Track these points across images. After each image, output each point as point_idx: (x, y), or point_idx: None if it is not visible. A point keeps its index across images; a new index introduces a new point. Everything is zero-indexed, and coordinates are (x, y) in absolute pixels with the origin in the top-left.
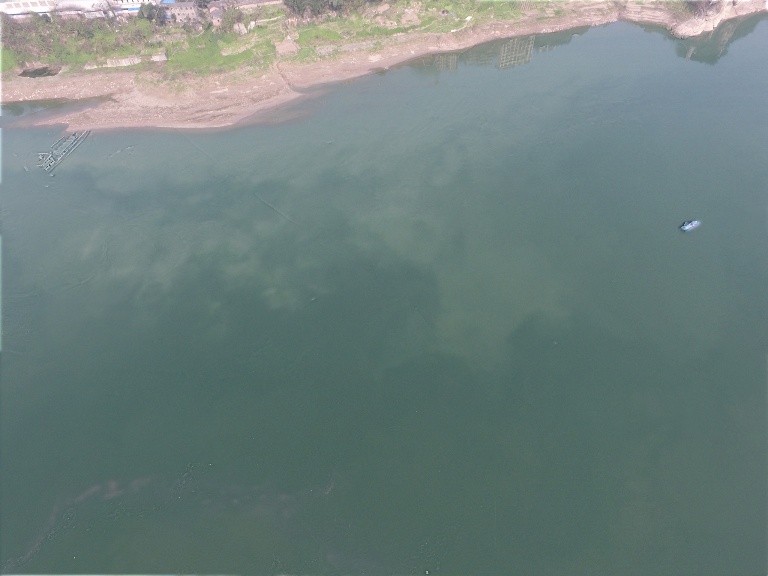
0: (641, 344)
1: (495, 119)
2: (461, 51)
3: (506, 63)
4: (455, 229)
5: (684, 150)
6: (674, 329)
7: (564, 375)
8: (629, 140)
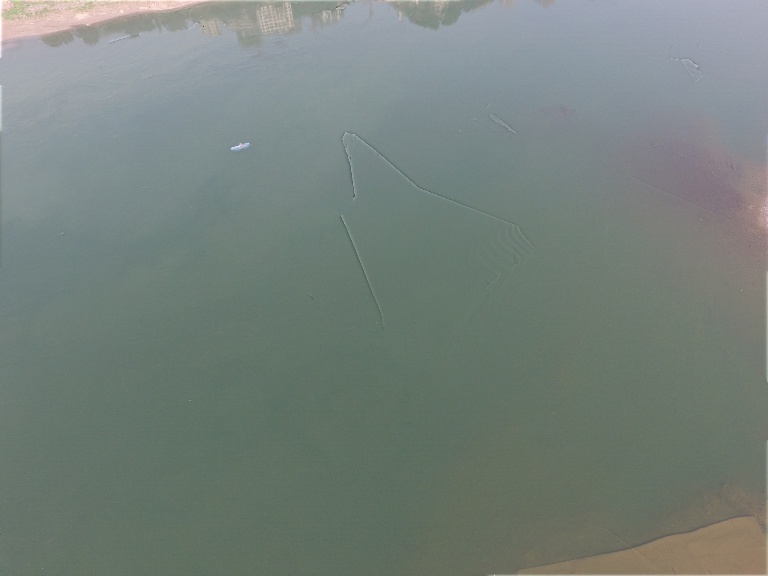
0: (131, 232)
1: (157, 67)
2: (169, 11)
3: (268, 29)
4: (51, 153)
5: (307, 92)
6: (165, 220)
7: (49, 255)
8: (261, 84)
